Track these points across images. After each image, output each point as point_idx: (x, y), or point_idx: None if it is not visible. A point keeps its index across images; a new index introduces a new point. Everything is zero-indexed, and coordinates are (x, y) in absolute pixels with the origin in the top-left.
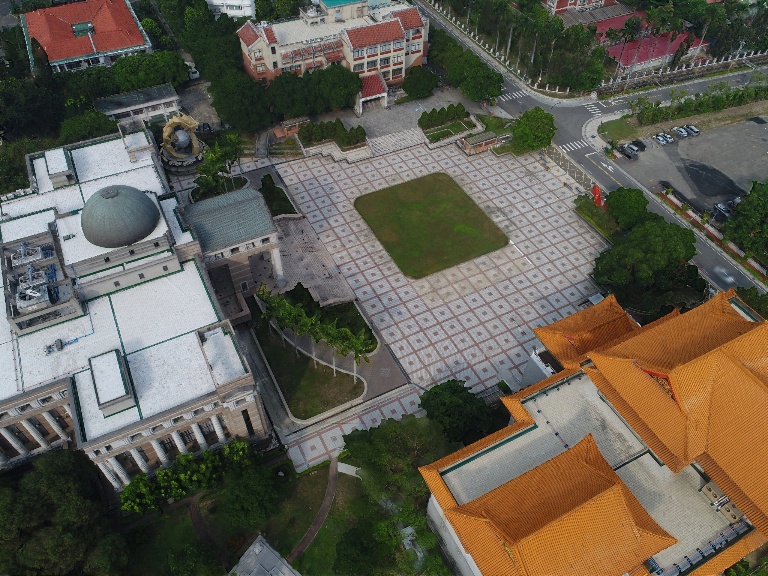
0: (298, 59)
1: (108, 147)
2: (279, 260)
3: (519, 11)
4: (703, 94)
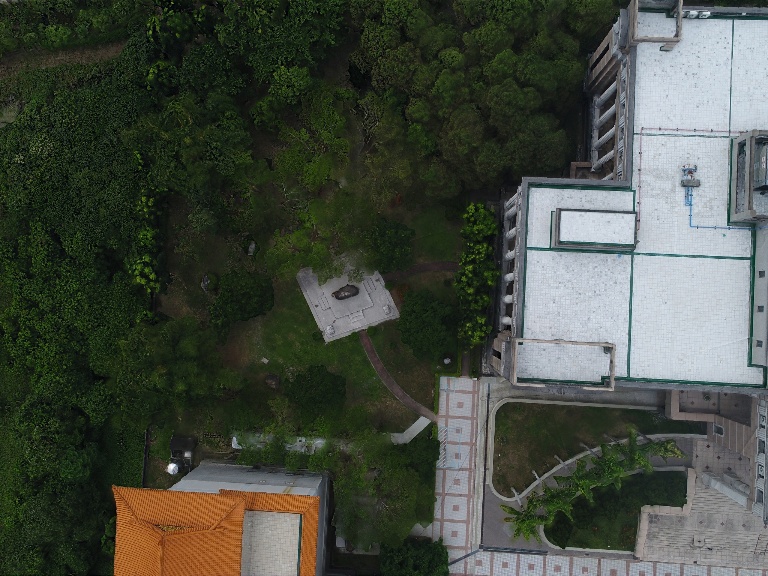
0: None
1: None
2: (733, 497)
3: None
4: None
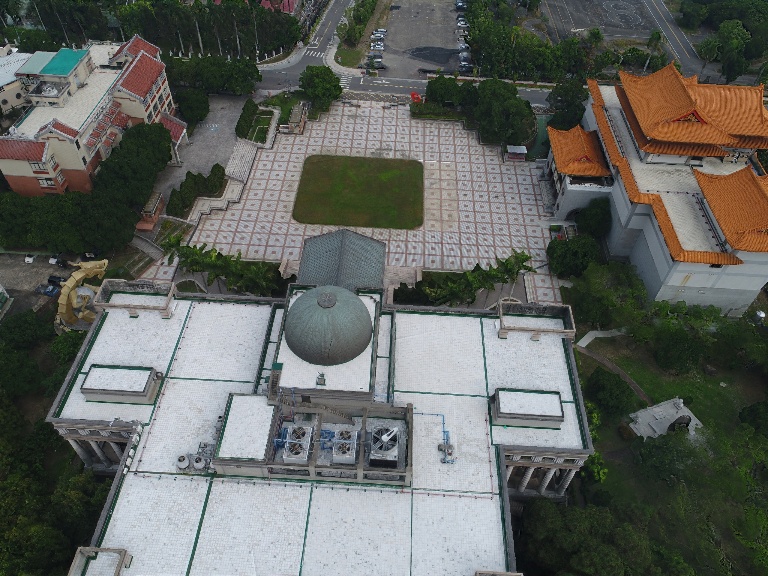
0: (97, 142)
1: (113, 333)
2: None
3: (186, 5)
4: (355, 6)
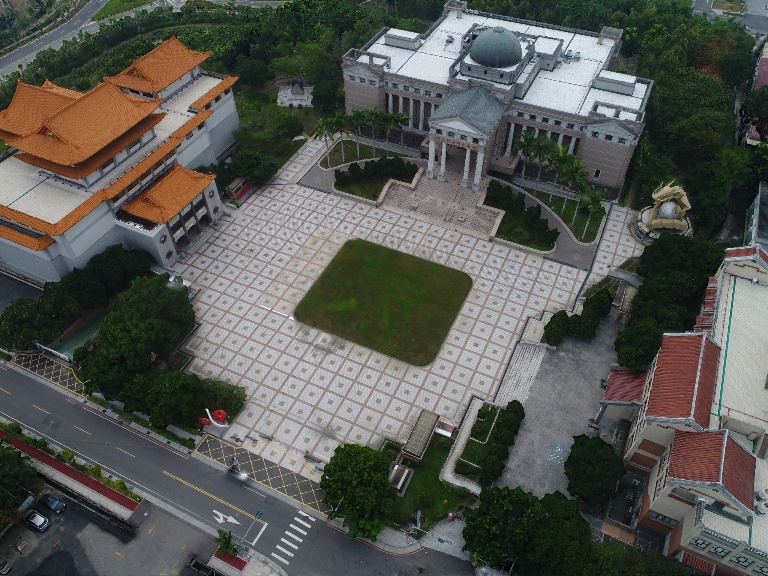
0: None
1: None
2: None
3: None
4: None
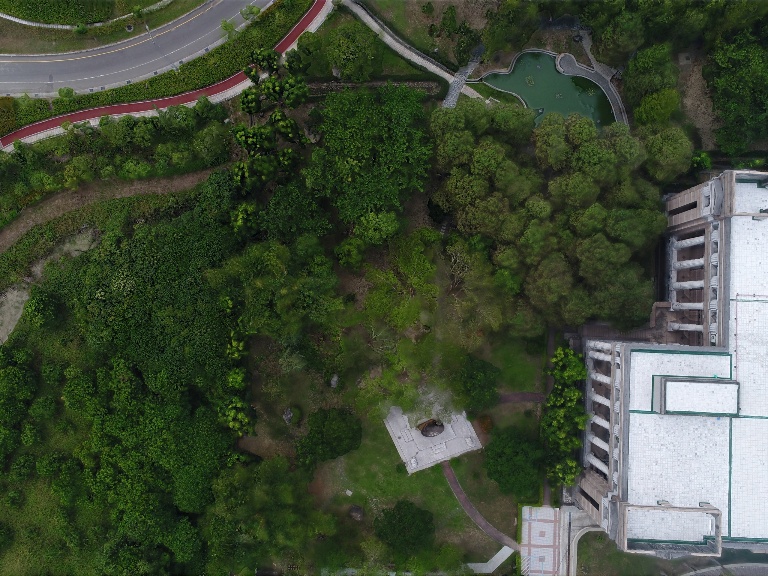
0: None
1: None
2: None
3: None
4: None
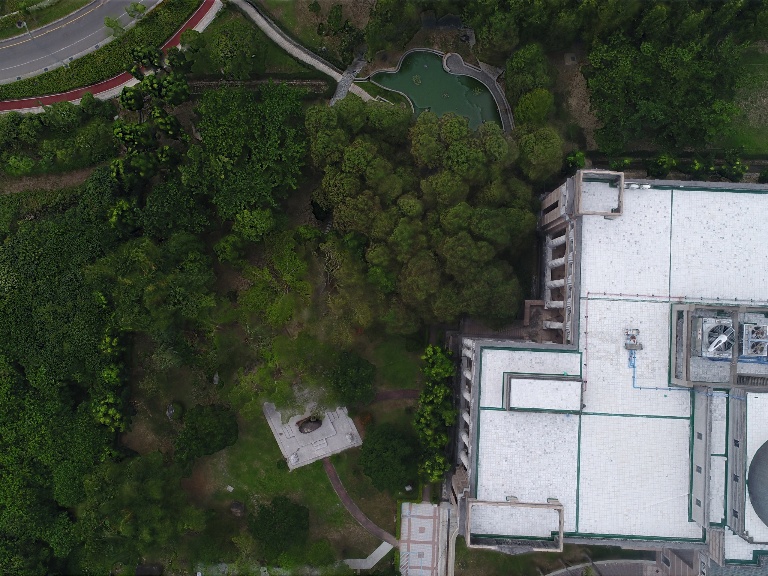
0: None
1: None
2: None
3: None
4: None
